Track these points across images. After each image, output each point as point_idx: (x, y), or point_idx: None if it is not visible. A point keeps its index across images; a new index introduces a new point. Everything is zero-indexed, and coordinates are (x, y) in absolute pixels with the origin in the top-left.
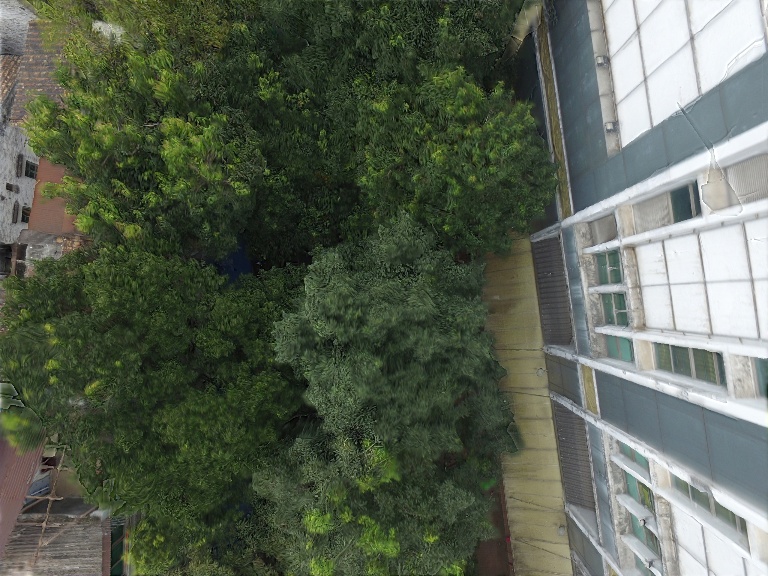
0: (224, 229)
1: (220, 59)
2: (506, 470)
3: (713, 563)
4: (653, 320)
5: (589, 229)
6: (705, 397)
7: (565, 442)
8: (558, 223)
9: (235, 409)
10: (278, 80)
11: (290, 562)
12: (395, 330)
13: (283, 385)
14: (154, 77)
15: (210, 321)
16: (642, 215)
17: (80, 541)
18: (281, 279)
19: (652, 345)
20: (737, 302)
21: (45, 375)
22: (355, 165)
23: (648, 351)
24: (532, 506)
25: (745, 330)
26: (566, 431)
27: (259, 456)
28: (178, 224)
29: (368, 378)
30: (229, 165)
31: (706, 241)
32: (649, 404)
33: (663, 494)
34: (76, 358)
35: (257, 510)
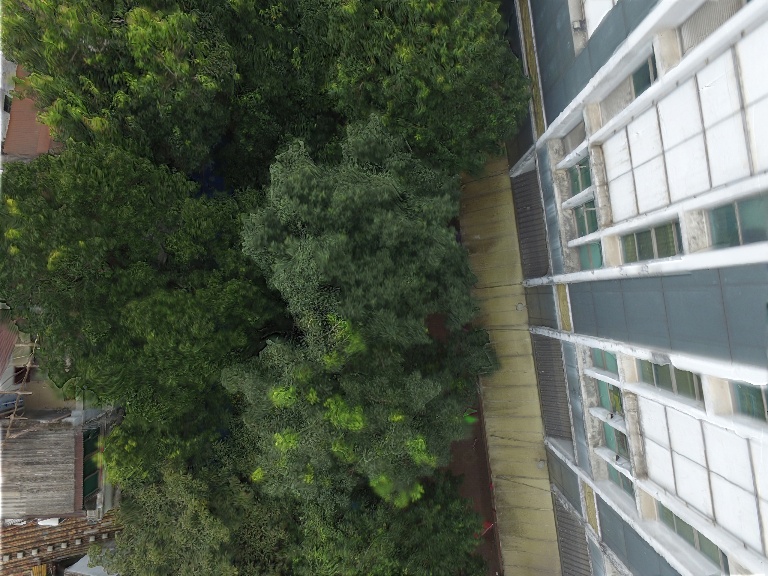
0: (195, 137)
1: None
2: (487, 409)
3: (676, 442)
4: (619, 214)
5: (562, 145)
6: (662, 262)
7: (544, 375)
8: (533, 145)
9: (204, 306)
10: None
11: (266, 481)
12: (360, 218)
13: (254, 290)
14: None
15: (181, 227)
16: (608, 110)
17: (52, 448)
18: (255, 195)
19: (619, 241)
20: (691, 160)
21: (7, 249)
22: (330, 86)
23: (615, 248)
24: (513, 443)
25: (699, 186)
26: (545, 364)
27: (231, 363)
28: (149, 130)
29: (330, 255)
30: (196, 59)
31: (664, 109)
32: (615, 297)
33: (630, 387)
34: (38, 232)
35: (234, 433)
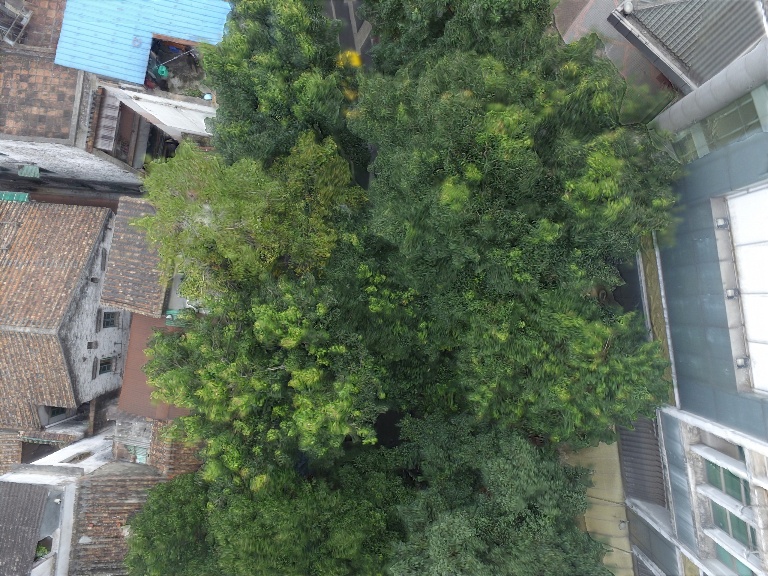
0: None
1: (327, 264)
2: None
3: None
4: None
5: None
6: None
7: None
8: None
9: None
10: (384, 282)
11: None
12: None
13: None
14: (282, 328)
15: (321, 543)
16: None
17: None
18: (383, 478)
19: None
20: None
21: None
22: (452, 349)
23: None
24: None
25: None
26: None
27: None
28: (290, 446)
29: None
30: (356, 413)
31: None
32: None
33: None
34: None
35: None
